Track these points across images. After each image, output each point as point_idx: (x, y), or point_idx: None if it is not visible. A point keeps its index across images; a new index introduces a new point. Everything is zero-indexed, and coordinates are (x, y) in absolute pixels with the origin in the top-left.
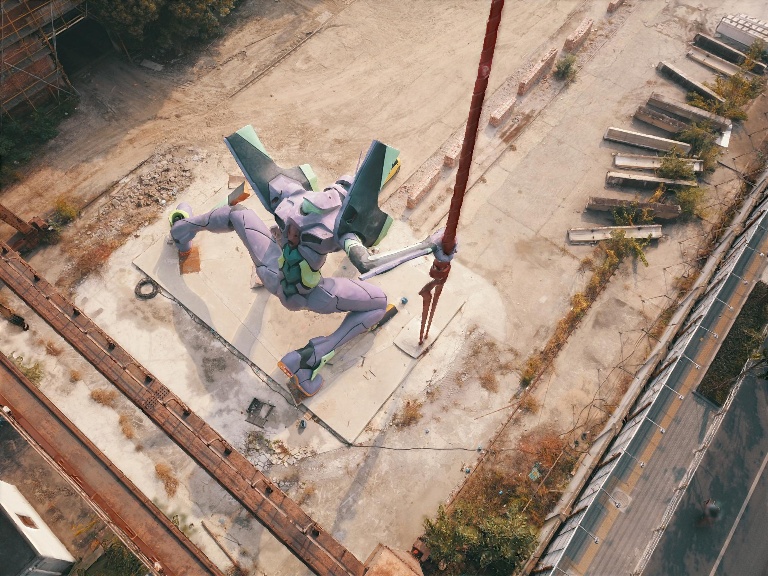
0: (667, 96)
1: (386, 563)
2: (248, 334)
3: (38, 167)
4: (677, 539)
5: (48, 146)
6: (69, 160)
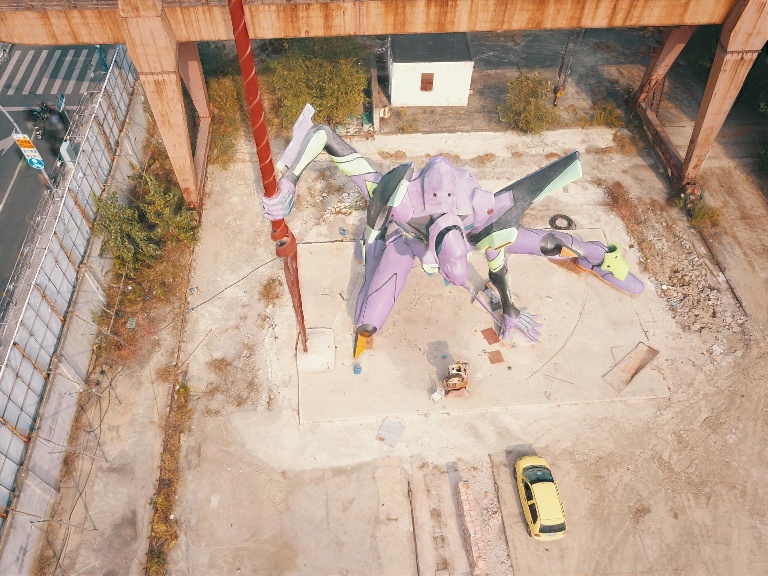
0: None
1: None
2: None
3: None
4: None
5: None
6: None
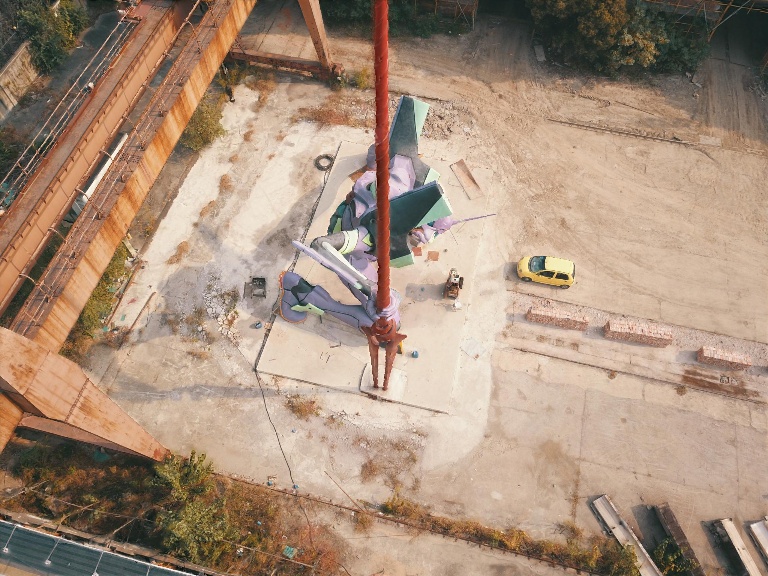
0: None
1: None
2: None
3: (391, 45)
4: None
5: (413, 39)
6: (409, 57)
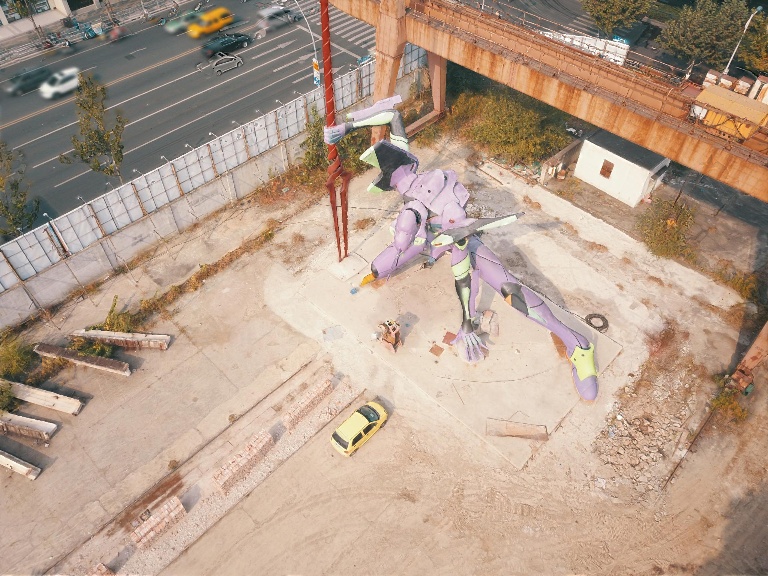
0: None
1: None
2: None
3: None
4: None
5: None
6: None
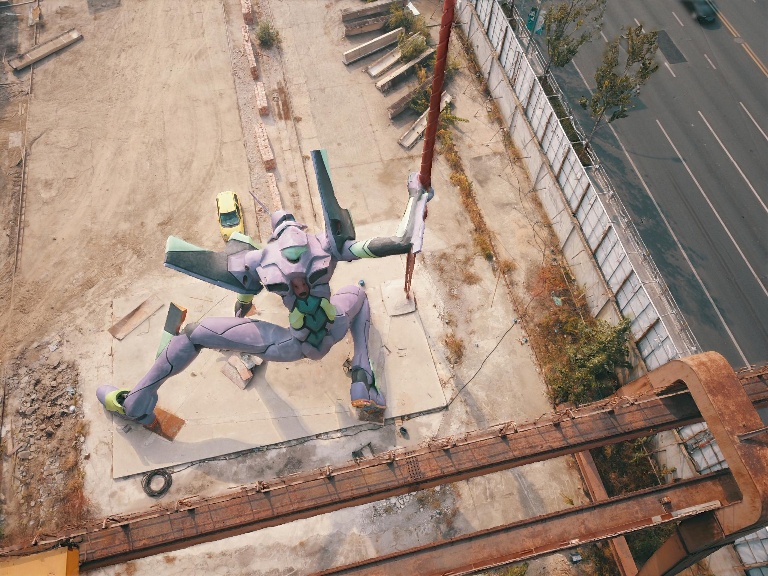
0: (348, 7)
1: (692, 361)
2: (286, 421)
3: None
4: (653, 255)
5: None
6: None
